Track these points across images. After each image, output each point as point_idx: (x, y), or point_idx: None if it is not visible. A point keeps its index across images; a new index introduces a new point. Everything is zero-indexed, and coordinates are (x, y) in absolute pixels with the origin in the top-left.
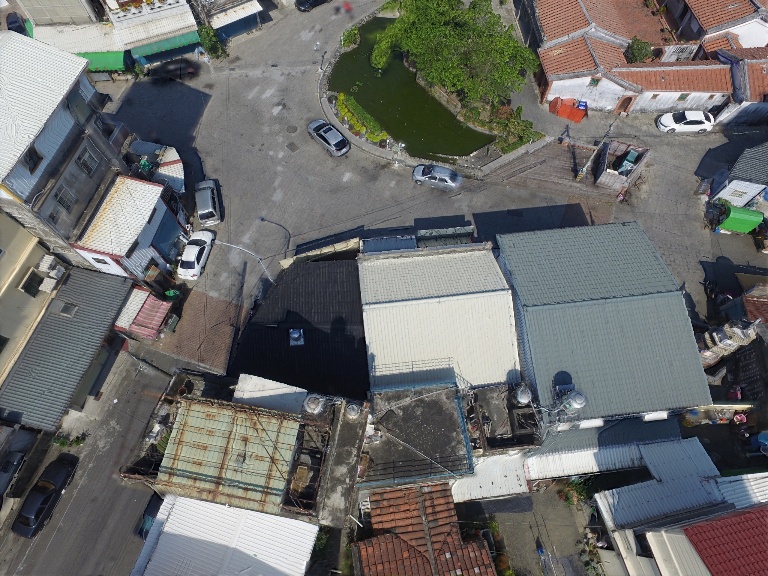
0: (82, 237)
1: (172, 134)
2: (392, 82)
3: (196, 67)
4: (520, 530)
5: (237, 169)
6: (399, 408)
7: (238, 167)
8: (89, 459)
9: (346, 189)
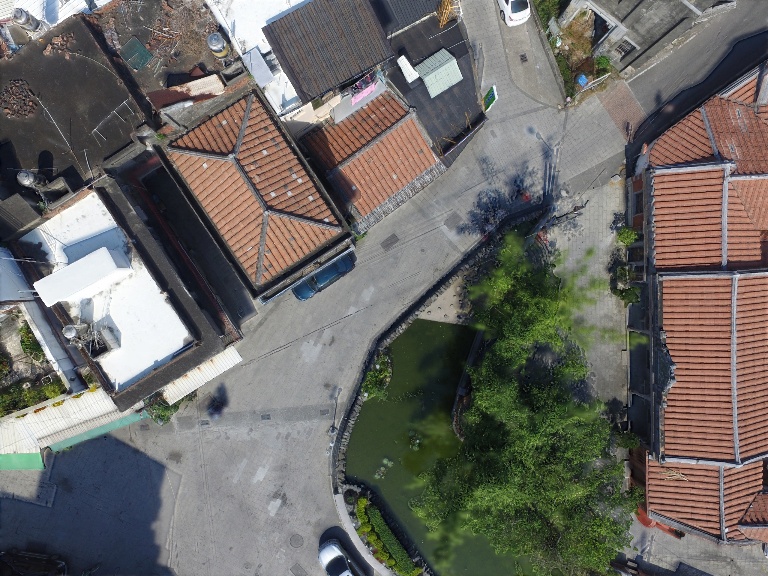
0: None
1: (137, 545)
2: (433, 459)
3: None
4: None
5: None
6: None
7: None
8: None
9: None
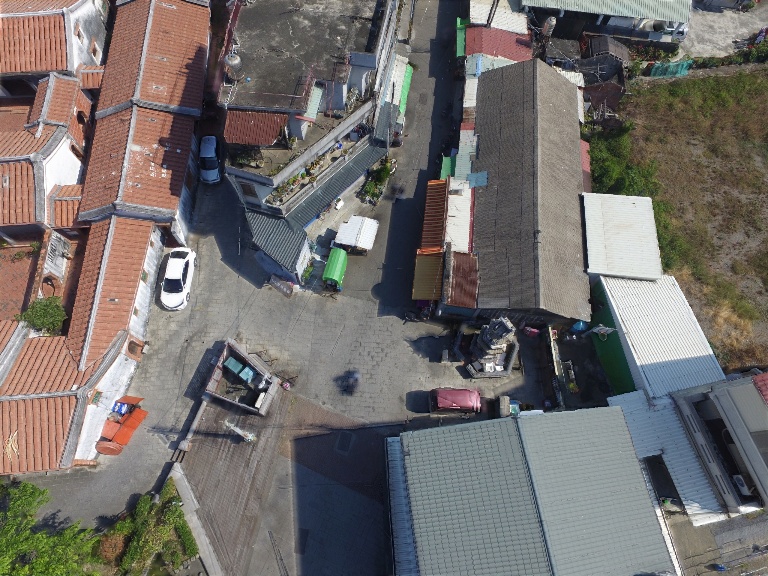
0: None
1: None
2: None
3: None
4: None
5: None
6: None
7: None
8: None
9: None
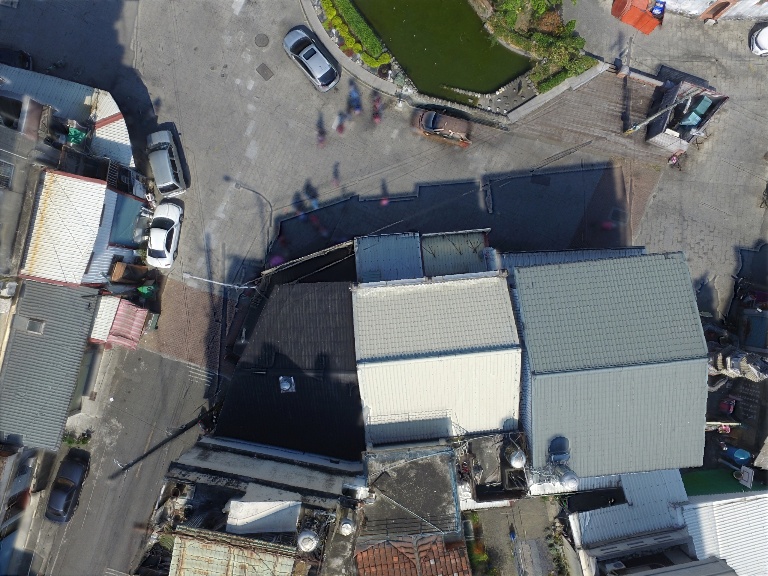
0: (24, 263)
1: (102, 46)
2: None
3: None
4: (497, 518)
5: (196, 107)
6: (393, 470)
7: (197, 104)
8: (100, 454)
9: (336, 141)
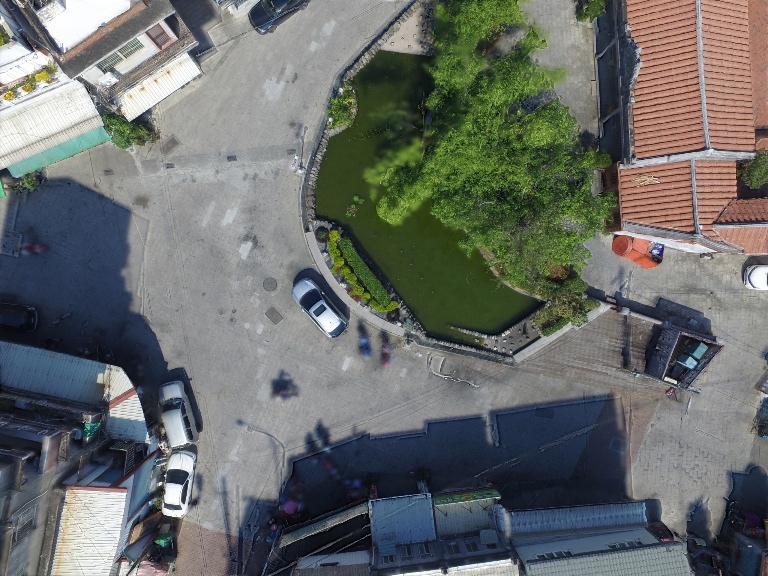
0: None
1: (108, 293)
2: None
3: (114, 161)
4: None
5: (206, 352)
6: None
7: (207, 349)
8: None
9: (347, 382)
